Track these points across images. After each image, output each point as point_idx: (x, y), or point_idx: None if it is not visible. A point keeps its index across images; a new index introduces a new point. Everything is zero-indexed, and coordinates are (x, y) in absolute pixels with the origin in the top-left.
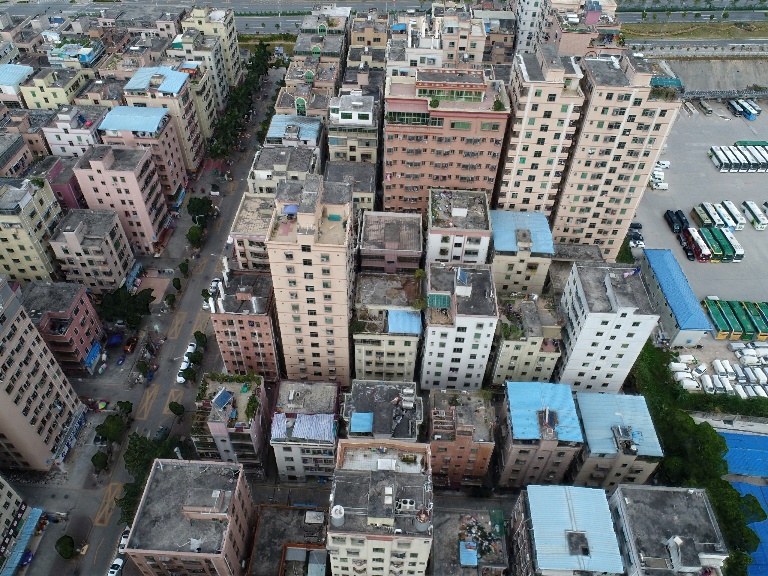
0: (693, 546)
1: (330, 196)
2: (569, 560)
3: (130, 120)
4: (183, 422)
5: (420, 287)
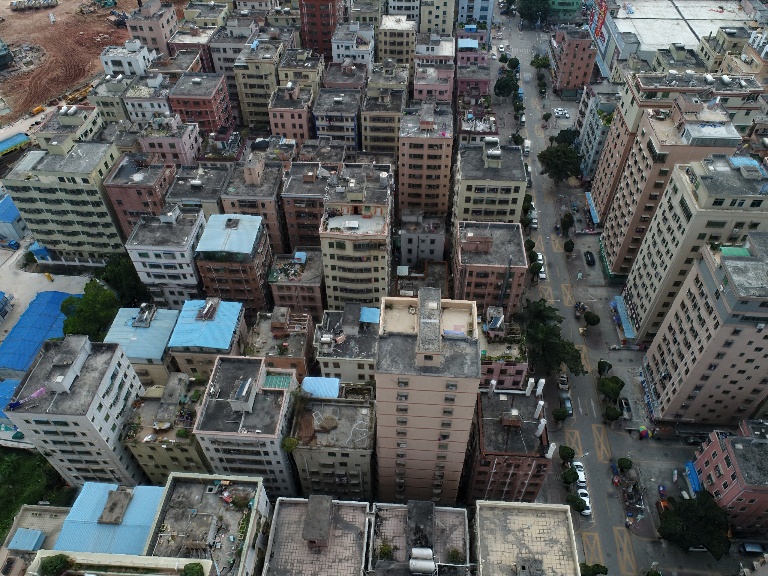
0: (163, 212)
1: (406, 351)
2: (242, 218)
3: None
4: (553, 420)
5: (294, 426)
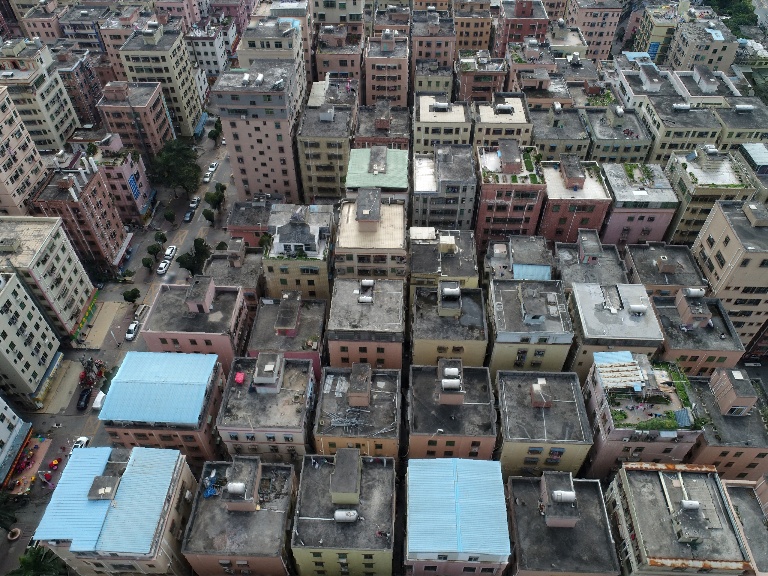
0: None
1: None
2: None
3: (166, 372)
4: (172, 225)
5: None
